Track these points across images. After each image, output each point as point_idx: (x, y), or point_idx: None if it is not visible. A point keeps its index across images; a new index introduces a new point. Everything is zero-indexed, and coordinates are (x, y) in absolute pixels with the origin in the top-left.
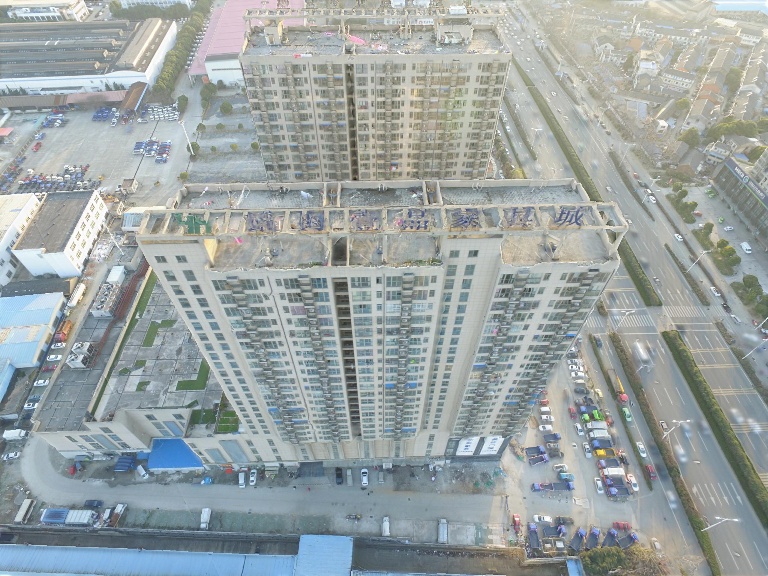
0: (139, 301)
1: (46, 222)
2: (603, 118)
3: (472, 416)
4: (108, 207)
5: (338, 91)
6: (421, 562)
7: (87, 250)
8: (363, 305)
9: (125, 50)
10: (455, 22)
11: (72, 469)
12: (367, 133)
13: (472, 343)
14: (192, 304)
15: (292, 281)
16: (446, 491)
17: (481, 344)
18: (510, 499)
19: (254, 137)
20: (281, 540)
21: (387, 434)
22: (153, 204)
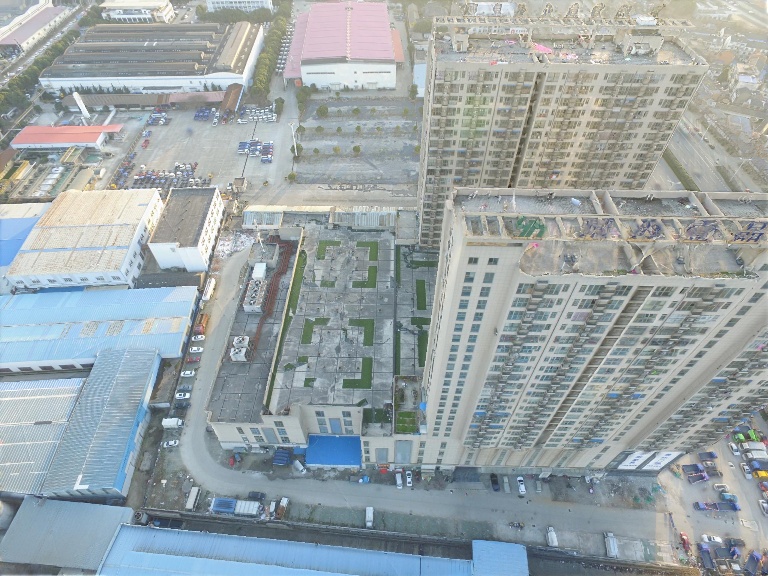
0: (290, 298)
1: (175, 217)
2: (704, 132)
3: (672, 430)
4: (224, 204)
5: (522, 99)
6: (588, 575)
7: (211, 246)
8: (650, 314)
9: (221, 52)
10: (643, 33)
11: (232, 460)
12: (538, 141)
13: (722, 357)
14: (470, 306)
15: (596, 287)
16: (606, 504)
17: (736, 359)
18: (674, 516)
19: (353, 140)
20: (445, 543)
21: (573, 443)
22: (265, 203)
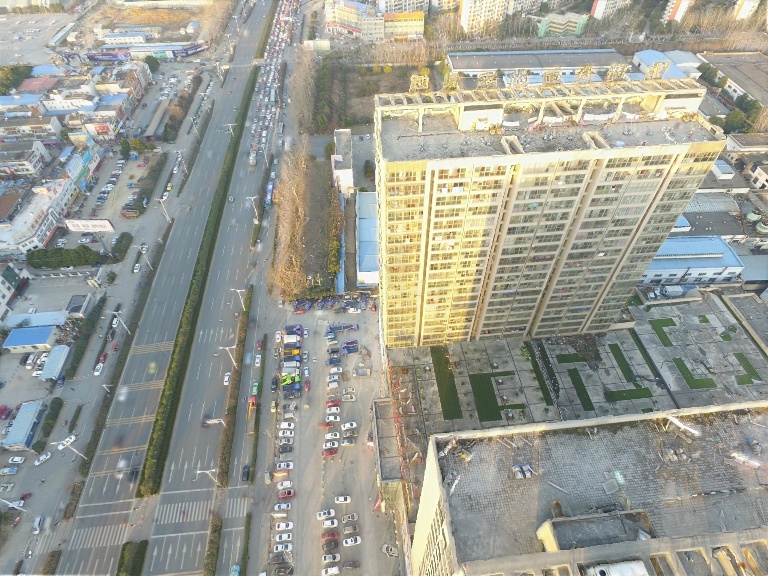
0: None
1: None
2: None
3: None
4: None
5: None
6: None
7: None
8: None
9: None
10: None
11: None
12: None
13: None
14: None
15: None
16: None
17: None
18: (376, 320)
19: None
20: None
21: None
22: None
